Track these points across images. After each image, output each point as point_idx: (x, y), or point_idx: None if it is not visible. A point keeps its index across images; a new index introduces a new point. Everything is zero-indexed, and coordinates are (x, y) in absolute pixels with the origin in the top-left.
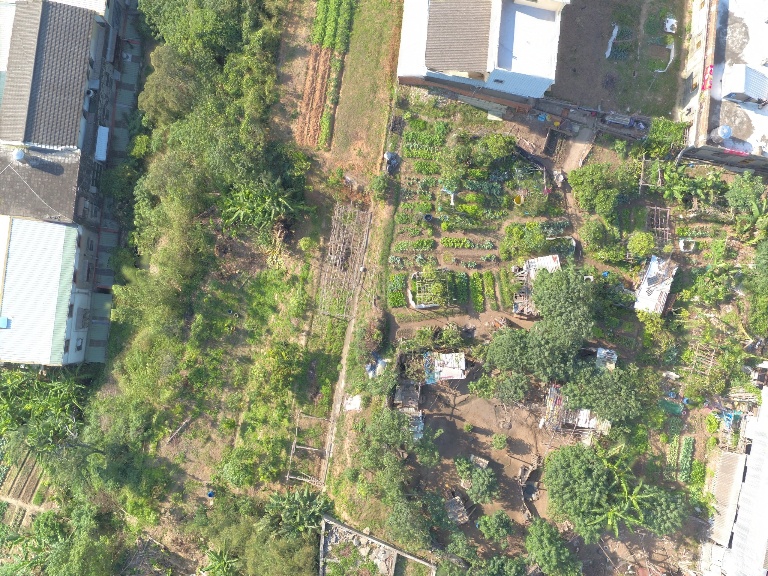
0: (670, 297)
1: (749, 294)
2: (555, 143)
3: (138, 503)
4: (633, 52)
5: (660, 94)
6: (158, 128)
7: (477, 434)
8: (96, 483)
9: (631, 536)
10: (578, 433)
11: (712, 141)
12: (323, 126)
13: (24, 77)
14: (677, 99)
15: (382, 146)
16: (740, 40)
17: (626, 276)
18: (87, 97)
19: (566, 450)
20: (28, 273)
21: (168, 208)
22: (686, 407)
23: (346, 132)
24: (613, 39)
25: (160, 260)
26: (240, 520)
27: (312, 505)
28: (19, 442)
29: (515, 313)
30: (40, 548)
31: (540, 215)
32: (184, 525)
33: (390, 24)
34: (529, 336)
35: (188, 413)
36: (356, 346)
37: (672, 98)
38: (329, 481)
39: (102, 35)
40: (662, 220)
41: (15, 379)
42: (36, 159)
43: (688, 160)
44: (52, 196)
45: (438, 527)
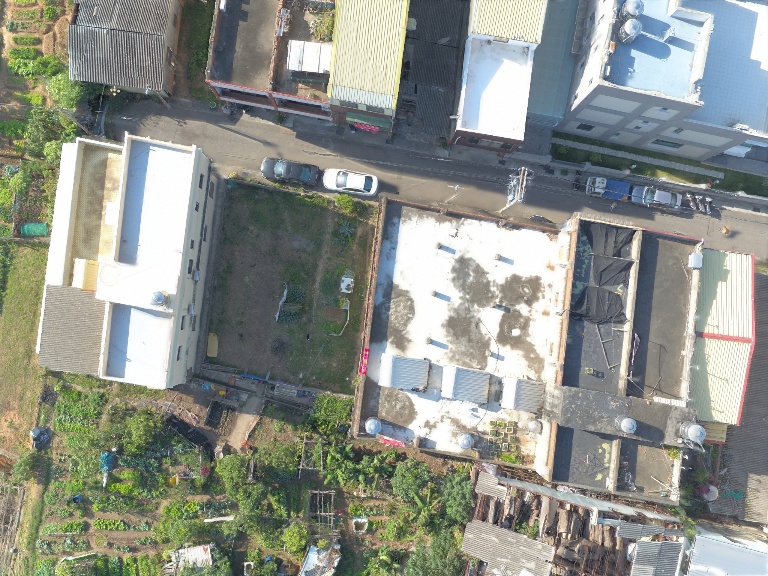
0: None
1: None
2: (220, 414)
3: None
4: (307, 313)
5: (335, 359)
6: None
7: None
8: None
9: None
10: None
11: None
12: None
13: None
14: (356, 363)
15: None
16: (404, 315)
17: (293, 559)
18: None
19: None
20: None
21: None
22: None
23: None
24: (282, 302)
25: None
26: None
27: None
28: None
29: None
30: None
31: (201, 493)
32: None
33: None
34: None
35: None
36: None
37: (350, 362)
38: None
39: None
40: (327, 504)
41: None
42: None
43: None
44: None
45: None
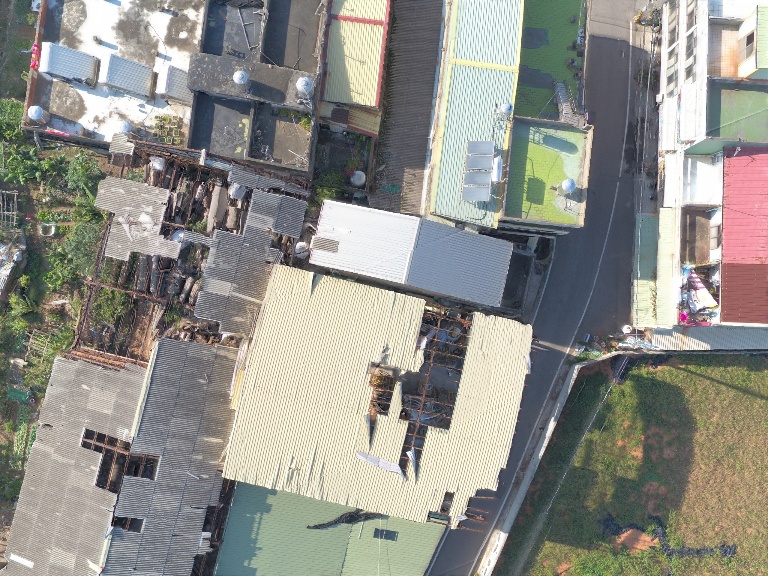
0: (11, 282)
1: (96, 279)
2: None
3: None
4: (1, 32)
5: None
6: None
7: None
8: None
9: None
10: None
11: (37, 122)
12: None
13: None
14: None
15: None
16: (76, 18)
17: None
18: None
19: None
20: None
21: None
22: (37, 395)
23: None
24: None
25: None
26: None
27: None
28: None
29: None
30: None
31: None
32: None
33: None
34: None
35: None
36: None
37: None
38: None
39: None
40: (10, 204)
41: None
42: None
43: (54, 142)
44: None
45: None
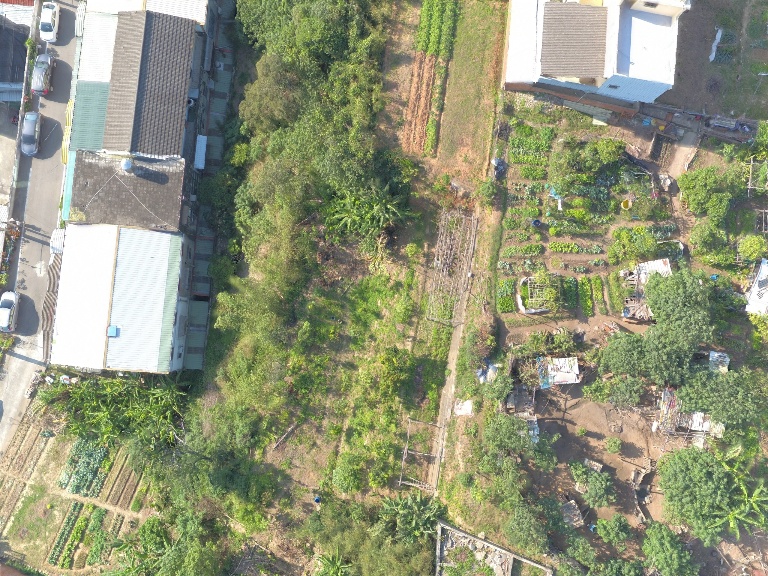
0: None
1: None
2: (660, 147)
3: (248, 509)
4: (736, 55)
5: (764, 97)
6: (256, 136)
7: (589, 438)
8: (199, 489)
9: (744, 538)
10: (692, 436)
11: None
12: (429, 133)
13: (129, 87)
14: None
15: (488, 152)
16: None
17: (733, 279)
18: (187, 106)
19: (682, 453)
20: (135, 282)
21: (272, 216)
22: None
23: (452, 138)
24: (717, 43)
25: (269, 268)
26: (354, 525)
27: (426, 510)
28: (138, 450)
29: (625, 317)
30: (146, 554)
31: (647, 219)
32: (291, 531)
33: (493, 30)
34: (645, 340)
35: (293, 419)
36: (466, 351)
37: None
38: (441, 486)
39: (199, 44)
40: None
41: (115, 387)
42: (141, 168)
43: None
44: (157, 205)
45: (552, 531)
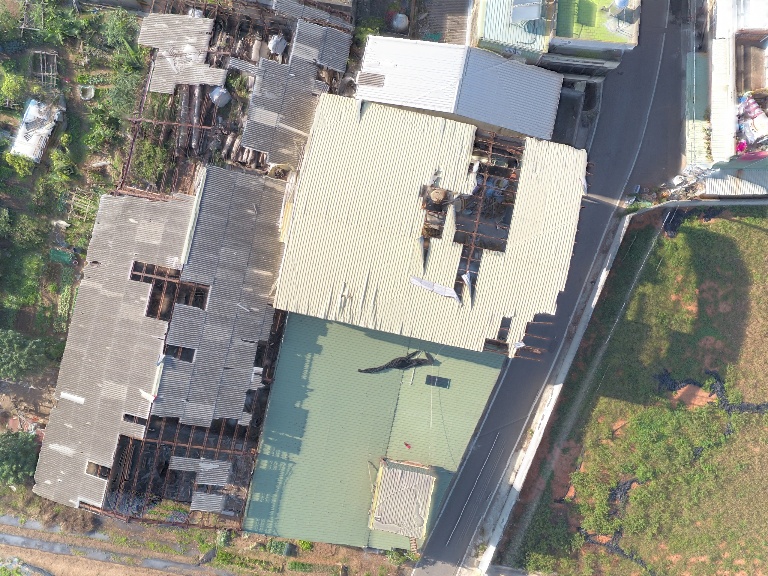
0: (53, 143)
1: (137, 138)
2: None
3: None
4: None
5: None
6: None
7: None
8: None
9: (16, 389)
10: None
11: None
12: None
13: None
14: None
15: None
16: None
17: None
18: None
19: None
20: None
21: None
22: (80, 257)
23: None
24: None
25: None
26: None
27: None
28: None
29: None
30: None
31: None
32: None
33: None
34: None
35: None
36: None
37: None
38: None
39: None
40: (50, 65)
41: None
42: None
43: (92, 7)
44: None
45: None
